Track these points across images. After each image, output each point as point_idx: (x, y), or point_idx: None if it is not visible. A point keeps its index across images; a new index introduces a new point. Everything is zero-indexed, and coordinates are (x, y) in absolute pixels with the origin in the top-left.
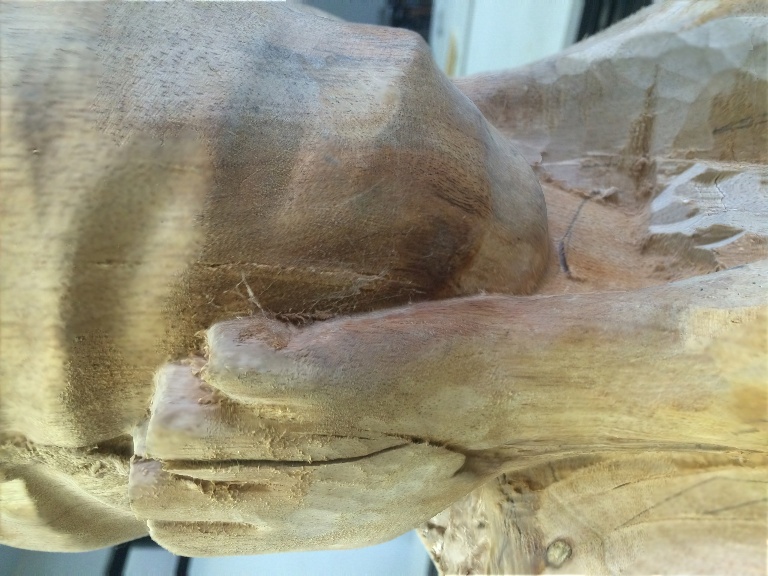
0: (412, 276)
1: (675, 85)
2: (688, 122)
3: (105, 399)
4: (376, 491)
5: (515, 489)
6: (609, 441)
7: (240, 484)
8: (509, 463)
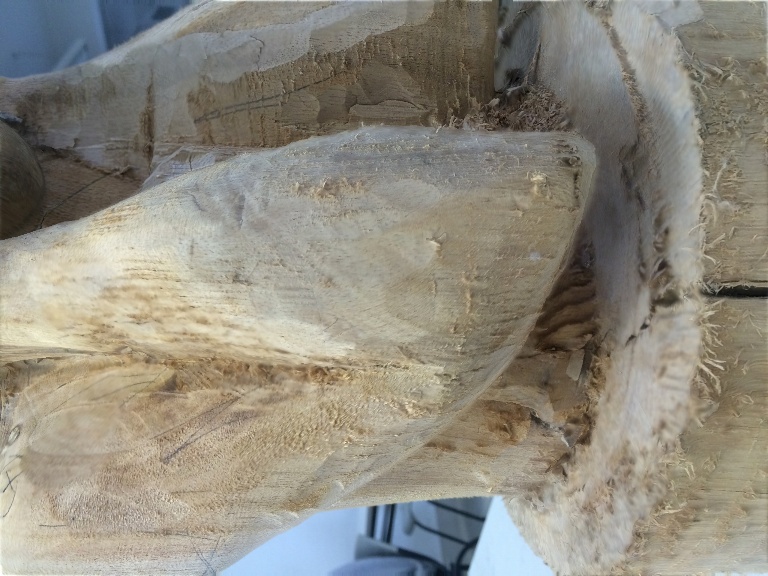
0: None
1: (164, 85)
2: (175, 114)
3: None
4: None
5: (9, 394)
6: None
7: None
8: None
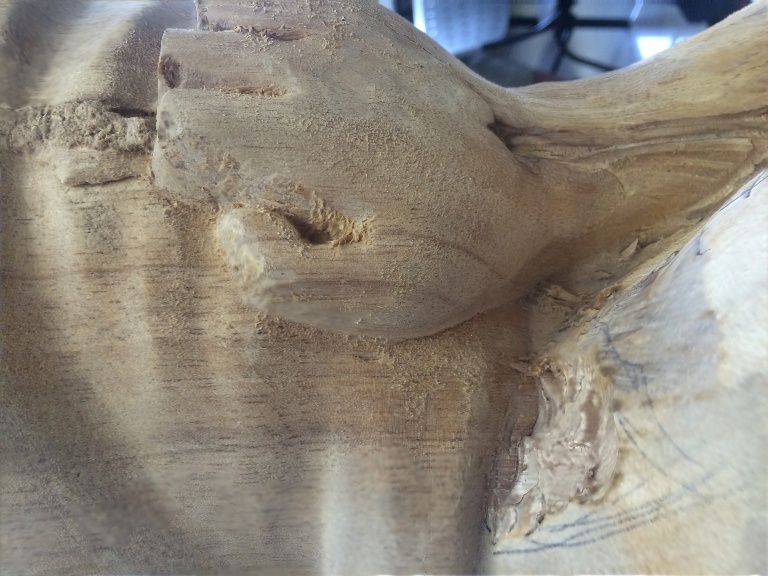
0: None
1: None
2: None
3: (147, 70)
4: (408, 78)
5: (591, 309)
6: (631, 132)
7: (276, 35)
8: (547, 165)
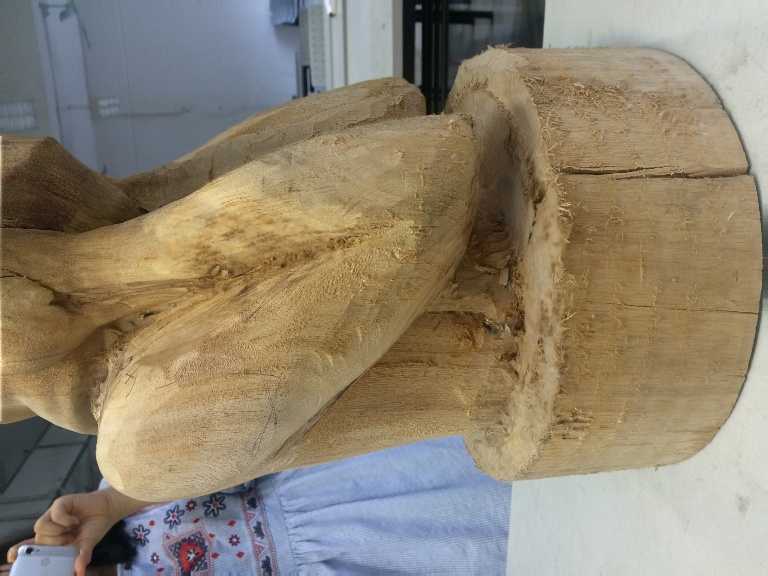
0: (34, 223)
1: (221, 167)
2: None
3: None
4: (2, 302)
5: (119, 349)
6: (128, 286)
7: None
8: (86, 307)
